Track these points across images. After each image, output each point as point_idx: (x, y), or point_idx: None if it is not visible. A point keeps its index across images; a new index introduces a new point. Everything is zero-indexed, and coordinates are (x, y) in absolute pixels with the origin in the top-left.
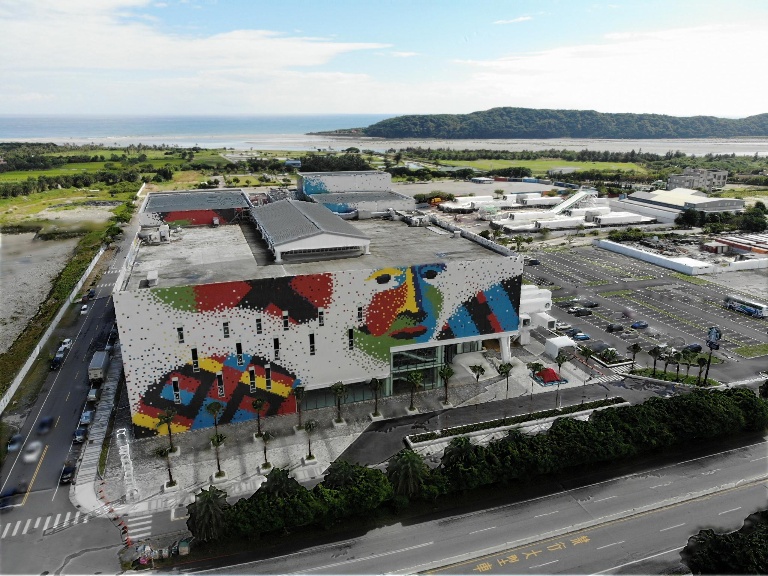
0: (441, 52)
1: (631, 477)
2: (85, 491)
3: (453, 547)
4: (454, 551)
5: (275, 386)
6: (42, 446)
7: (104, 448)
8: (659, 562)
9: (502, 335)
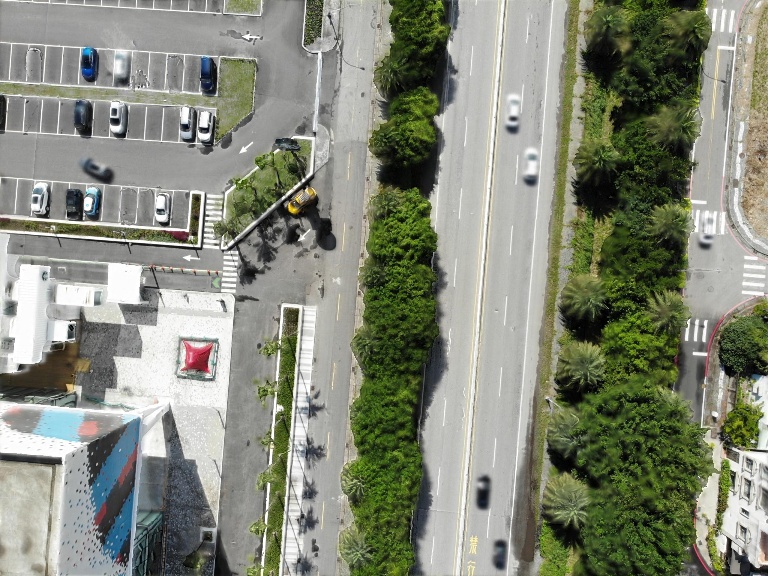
0: None
1: (422, 431)
2: None
3: None
4: None
5: None
6: None
7: None
8: (521, 500)
9: (140, 446)
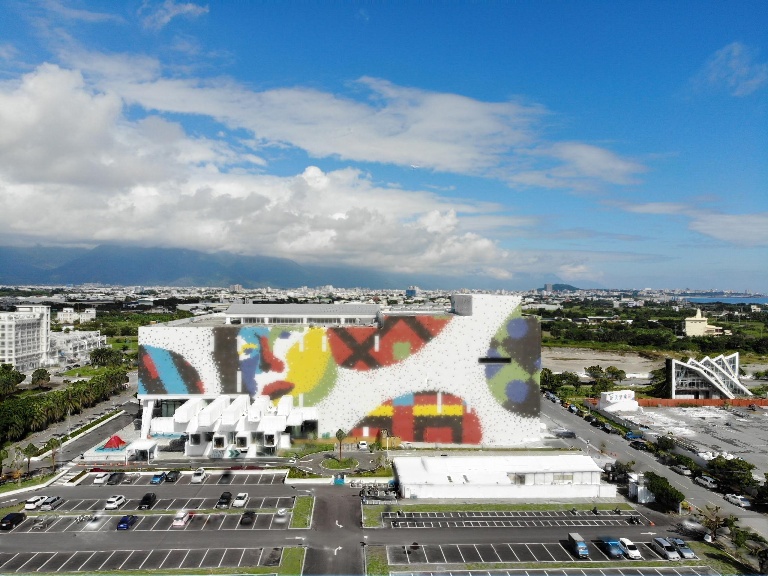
0: (398, 144)
1: None
2: None
3: None
4: None
5: None
6: None
7: None
8: None
9: None
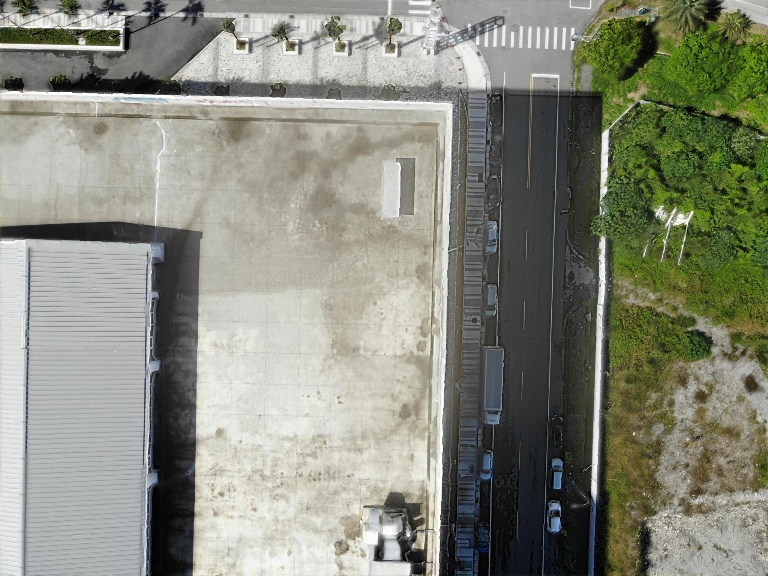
0: None
1: None
2: (476, 76)
3: None
4: None
5: None
6: (535, 187)
7: (465, 152)
8: None
9: None
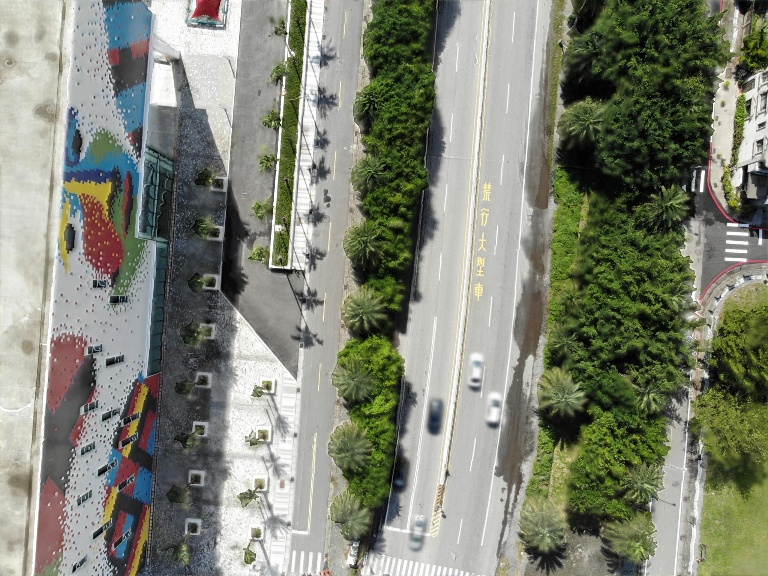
0: None
1: None
2: None
3: (449, 304)
4: (453, 306)
5: (138, 407)
6: None
7: None
8: (535, 146)
9: (152, 45)
